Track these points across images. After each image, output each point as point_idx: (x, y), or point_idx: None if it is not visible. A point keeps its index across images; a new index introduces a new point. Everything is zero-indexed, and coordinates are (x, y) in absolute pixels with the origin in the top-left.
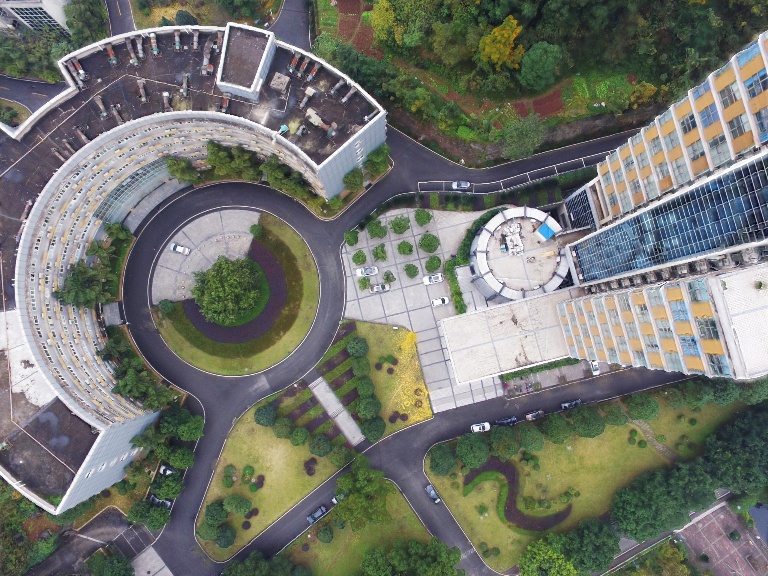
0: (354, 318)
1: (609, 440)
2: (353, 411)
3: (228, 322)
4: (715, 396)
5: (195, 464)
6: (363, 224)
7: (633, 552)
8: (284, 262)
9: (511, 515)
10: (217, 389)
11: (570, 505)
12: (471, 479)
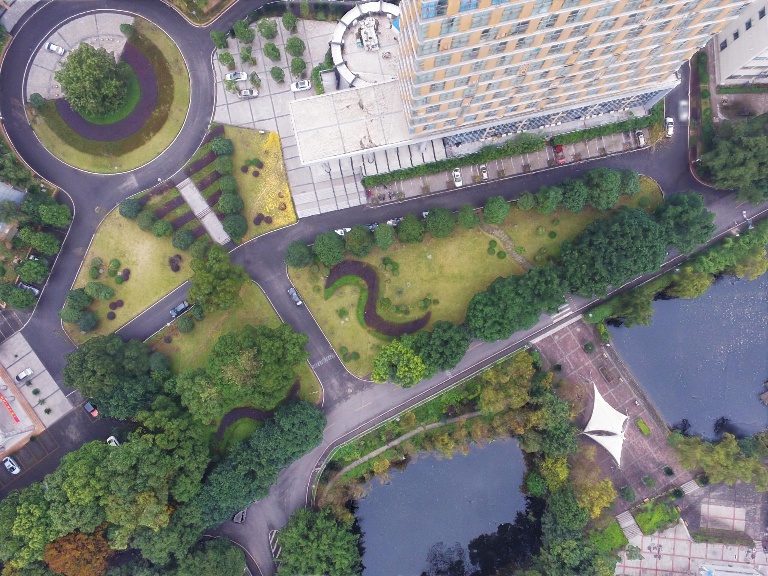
0: (223, 122)
1: (469, 250)
2: (218, 211)
3: (89, 107)
4: (565, 198)
5: (64, 256)
6: (233, 30)
7: (489, 361)
8: (155, 65)
9: (371, 320)
10: (87, 185)
11: (429, 313)
12: (332, 282)
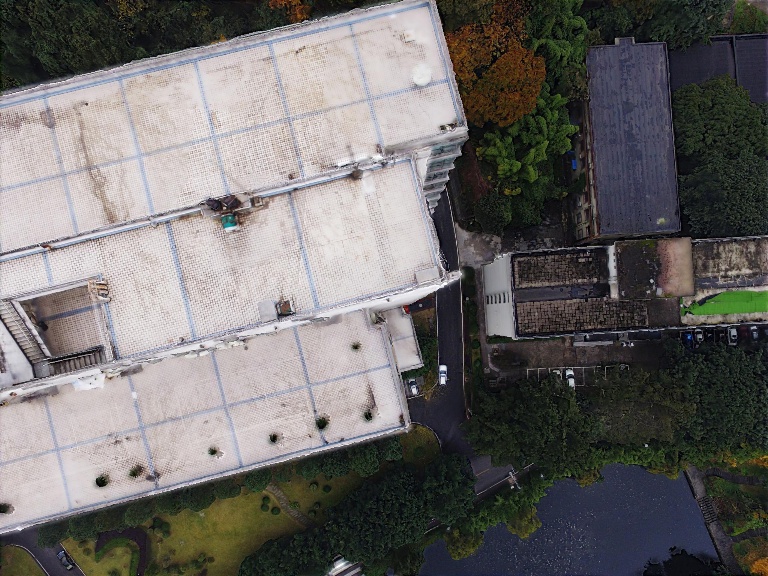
0: None
1: (243, 507)
2: None
3: None
4: (324, 469)
5: None
6: None
7: None
8: None
9: None
10: None
11: (205, 571)
12: (101, 546)
